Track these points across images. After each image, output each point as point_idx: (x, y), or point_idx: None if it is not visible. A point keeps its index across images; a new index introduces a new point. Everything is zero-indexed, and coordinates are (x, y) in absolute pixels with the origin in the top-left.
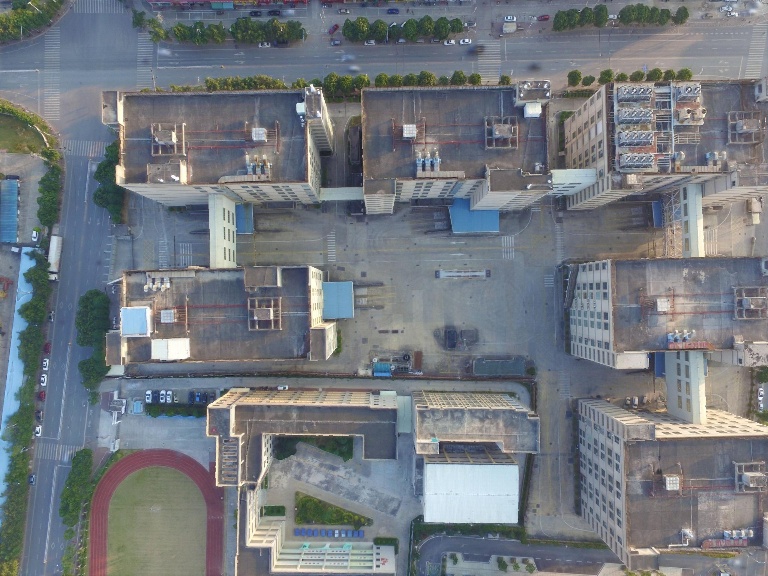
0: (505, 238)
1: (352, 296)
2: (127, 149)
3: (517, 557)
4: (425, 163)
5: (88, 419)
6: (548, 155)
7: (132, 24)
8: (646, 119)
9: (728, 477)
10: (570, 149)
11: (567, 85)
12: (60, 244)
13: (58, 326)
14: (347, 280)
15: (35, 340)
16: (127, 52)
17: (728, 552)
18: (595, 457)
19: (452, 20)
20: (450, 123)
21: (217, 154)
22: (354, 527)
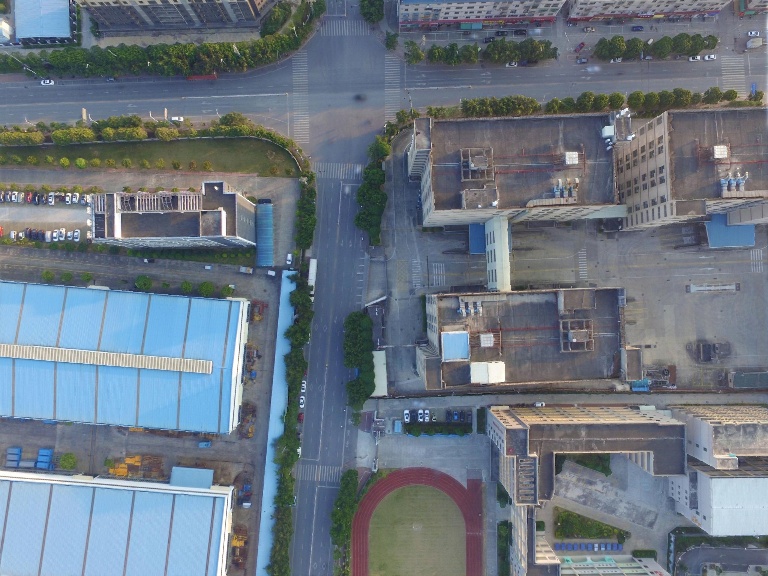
0: (753, 252)
1: None
2: (435, 175)
3: None
4: (731, 183)
5: (346, 439)
6: None
7: None
8: None
9: None
10: None
11: None
12: (316, 267)
13: (313, 348)
14: None
15: (301, 363)
16: (374, 74)
17: None
18: None
19: (707, 37)
20: (752, 143)
21: (523, 178)
22: (618, 541)
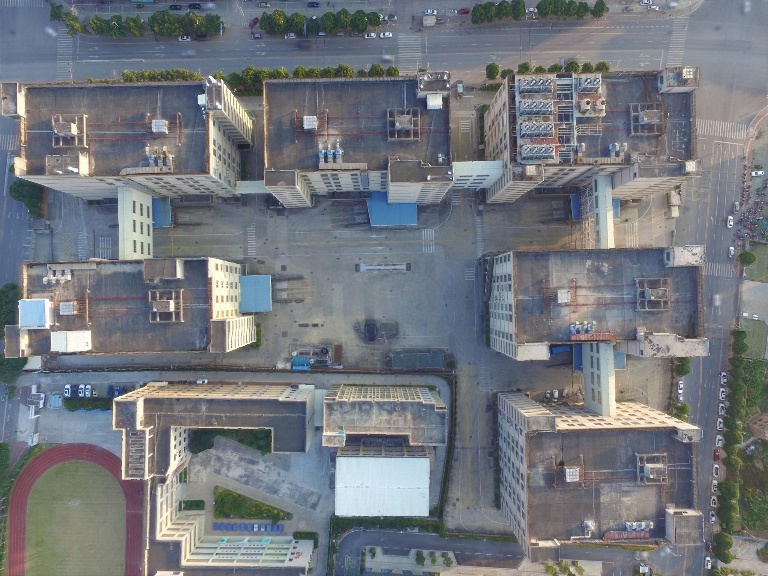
0: (425, 231)
1: (270, 289)
2: (28, 141)
3: (437, 551)
4: (327, 155)
5: (7, 413)
6: (450, 147)
7: (50, 17)
8: (546, 110)
9: (630, 469)
10: (487, 142)
11: (488, 78)
12: None
13: None
14: (267, 274)
15: None
16: (47, 46)
17: (648, 545)
18: (508, 450)
19: (369, 13)
20: (353, 115)
21: (119, 146)
22: (272, 521)
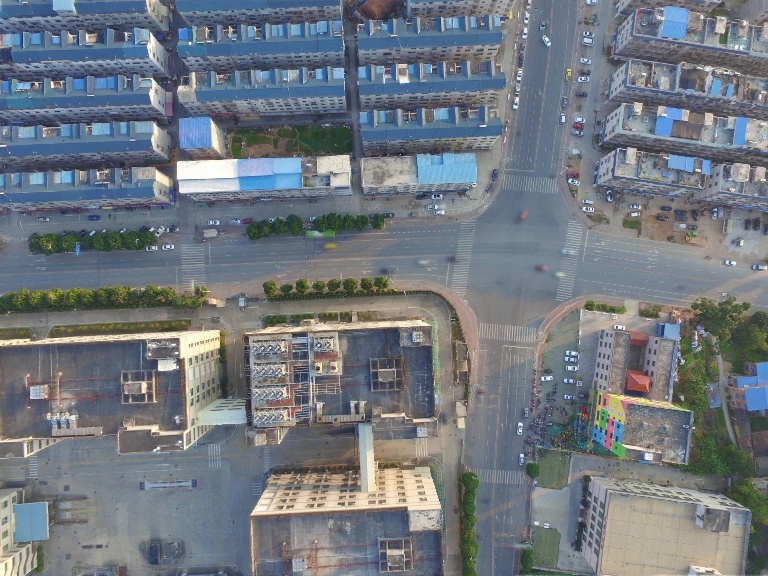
0: (211, 446)
1: (46, 517)
2: None
3: None
4: (60, 421)
5: None
6: (186, 409)
7: None
8: (278, 375)
9: None
10: None
11: None
12: None
13: None
14: (49, 495)
15: None
16: None
17: None
18: None
19: (141, 234)
20: (88, 377)
21: None
22: None
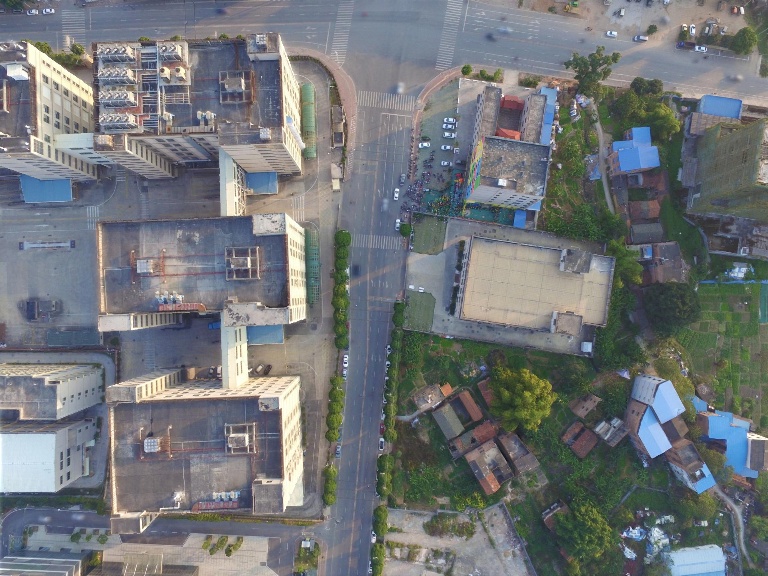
0: (90, 208)
1: None
2: None
3: (101, 529)
4: None
5: None
6: None
7: None
8: (124, 79)
9: (221, 439)
10: None
11: None
12: None
13: None
14: None
15: None
16: None
17: (312, 520)
18: None
19: None
20: None
21: None
22: None
